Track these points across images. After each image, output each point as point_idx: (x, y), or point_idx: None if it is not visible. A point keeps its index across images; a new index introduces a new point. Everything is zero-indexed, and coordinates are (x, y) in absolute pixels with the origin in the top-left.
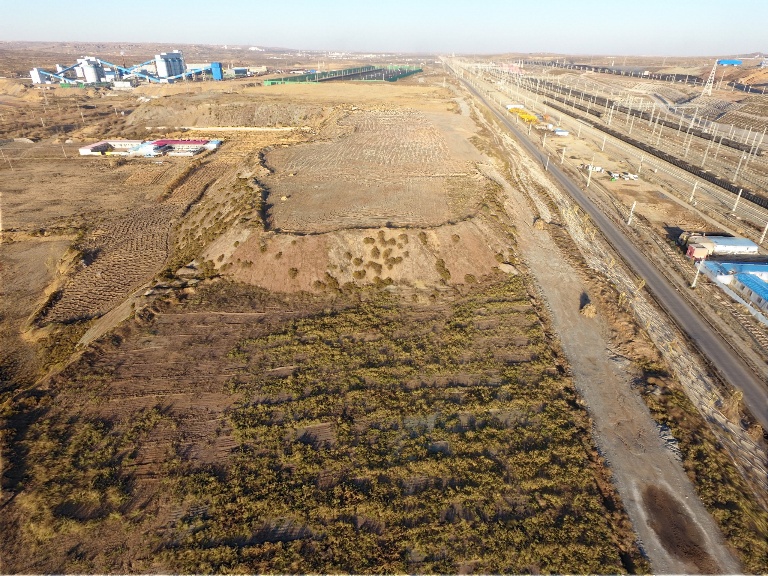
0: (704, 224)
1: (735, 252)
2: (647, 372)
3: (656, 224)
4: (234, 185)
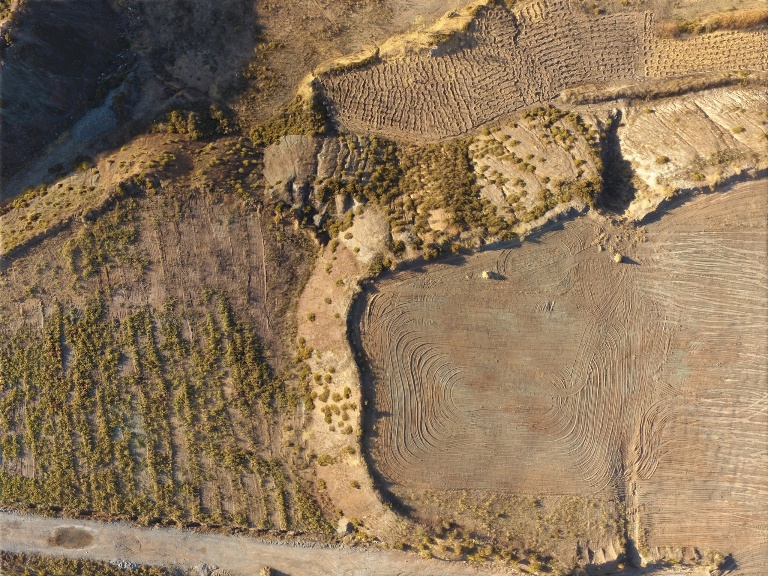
0: None
1: None
2: None
3: None
4: (571, 182)
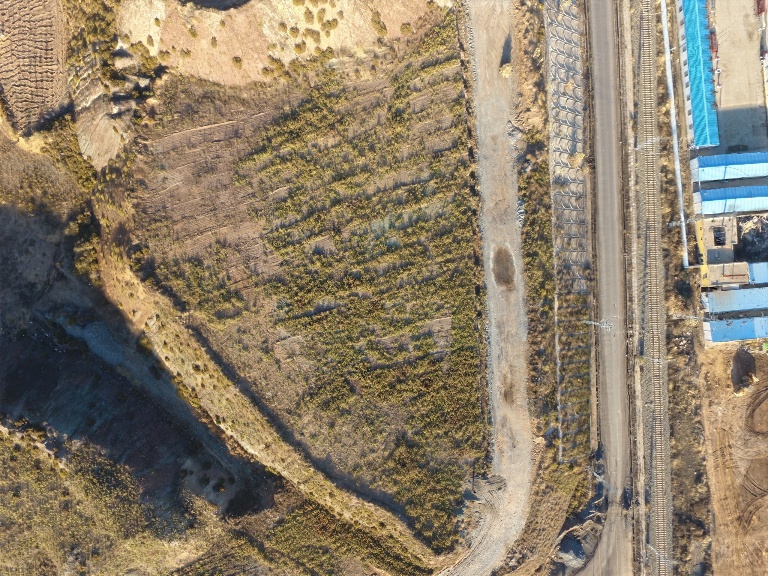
0: None
1: None
2: (529, 145)
3: None
4: None
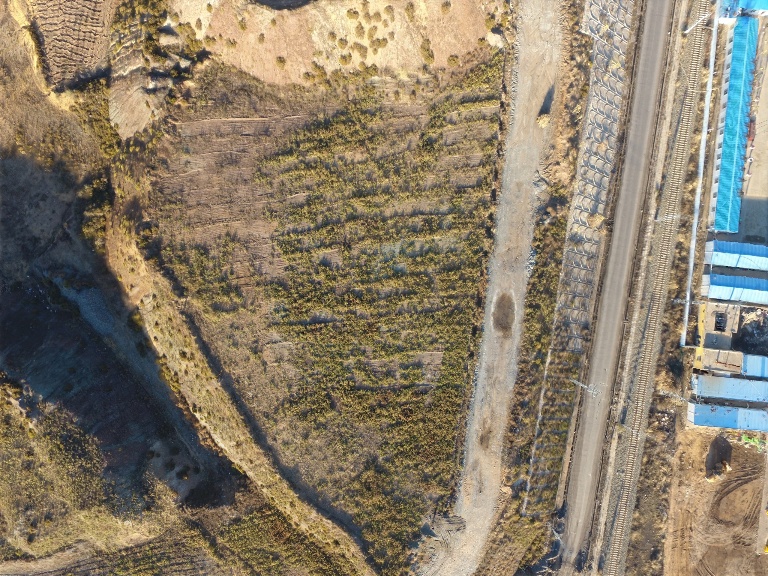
0: None
1: None
2: (552, 199)
3: None
4: None
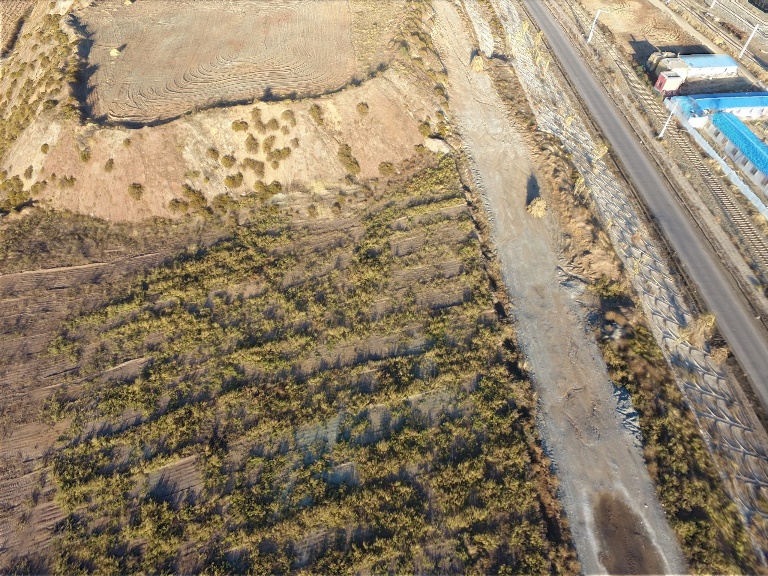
0: (677, 33)
1: (711, 76)
2: (605, 301)
3: (621, 38)
4: (41, 29)
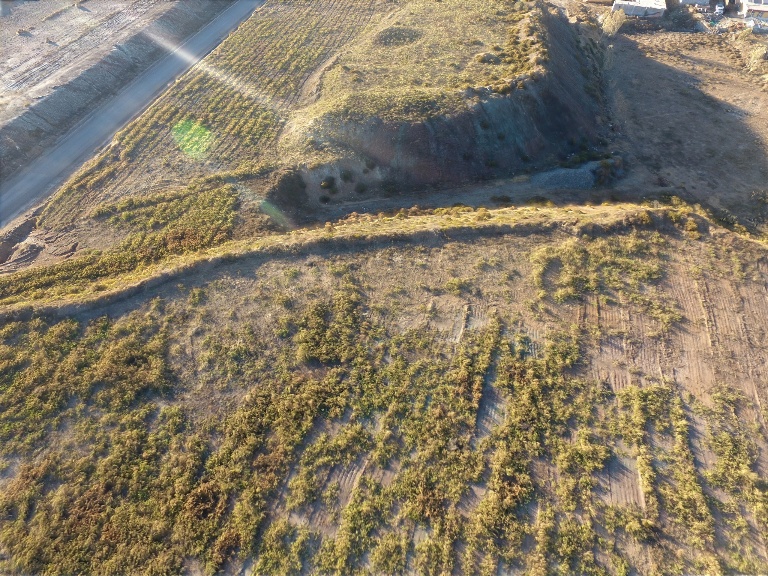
0: None
1: None
2: None
3: None
4: None
